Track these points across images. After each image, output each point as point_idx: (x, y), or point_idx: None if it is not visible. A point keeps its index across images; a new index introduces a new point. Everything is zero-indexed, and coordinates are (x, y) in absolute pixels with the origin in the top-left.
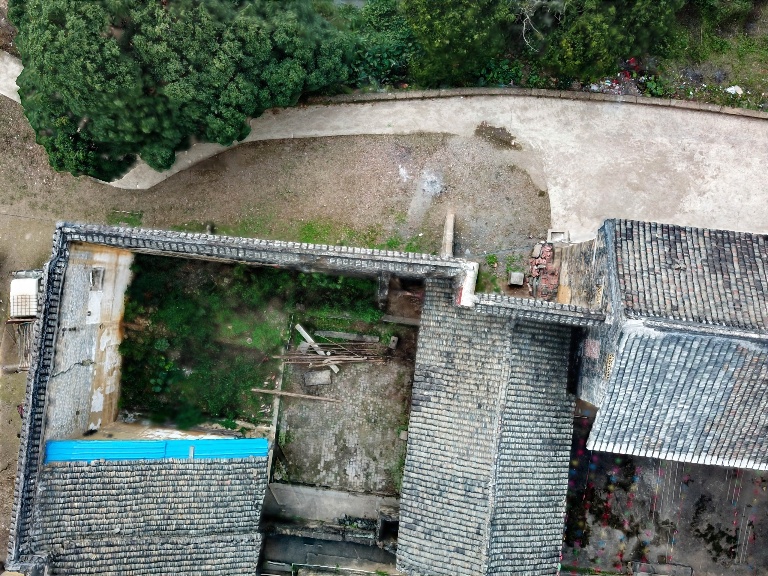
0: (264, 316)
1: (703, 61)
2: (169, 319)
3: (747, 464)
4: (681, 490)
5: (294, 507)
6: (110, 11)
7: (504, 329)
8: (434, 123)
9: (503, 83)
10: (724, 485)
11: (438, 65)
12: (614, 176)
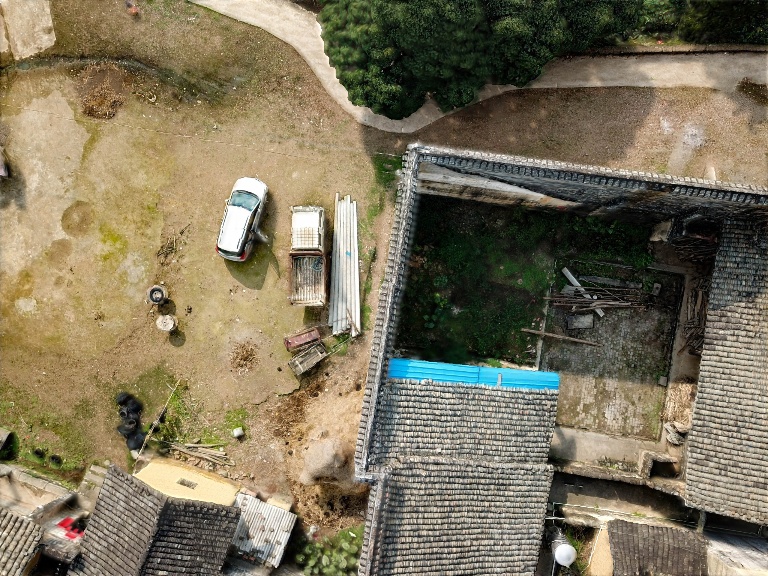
0: (532, 258)
1: None
2: (448, 256)
3: None
4: None
5: (555, 447)
6: None
7: None
8: (696, 78)
9: (764, 41)
10: None
11: (714, 19)
12: None
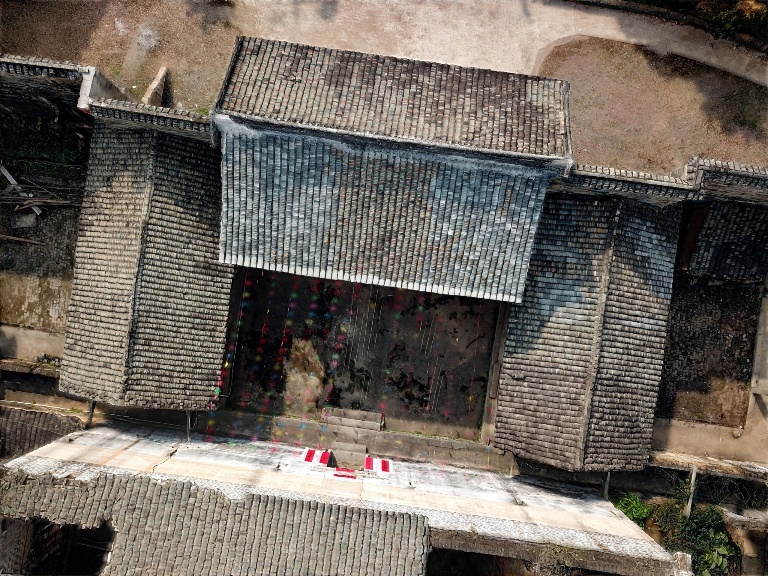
0: None
1: None
2: None
3: (373, 280)
4: (376, 339)
5: None
6: None
7: (149, 148)
8: None
9: None
10: (418, 335)
11: None
12: (323, 34)
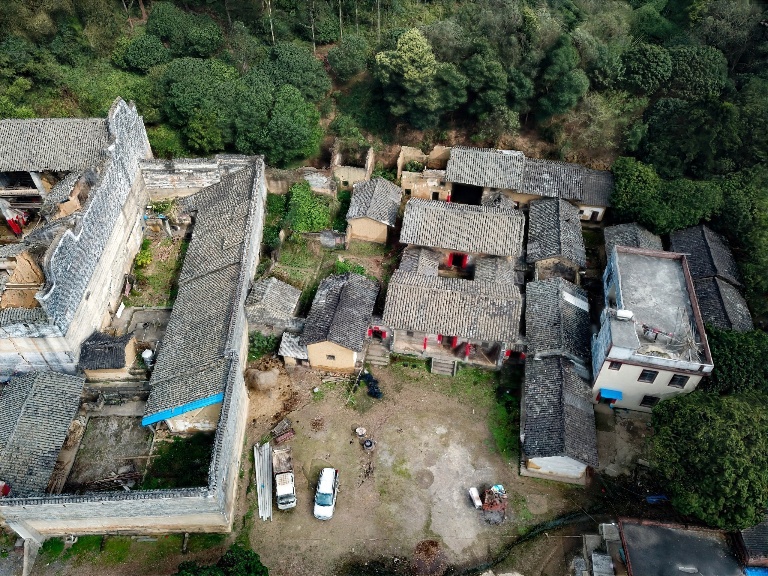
0: None
1: None
2: (200, 483)
3: None
4: None
5: None
6: None
7: None
8: None
9: None
10: None
11: None
12: None
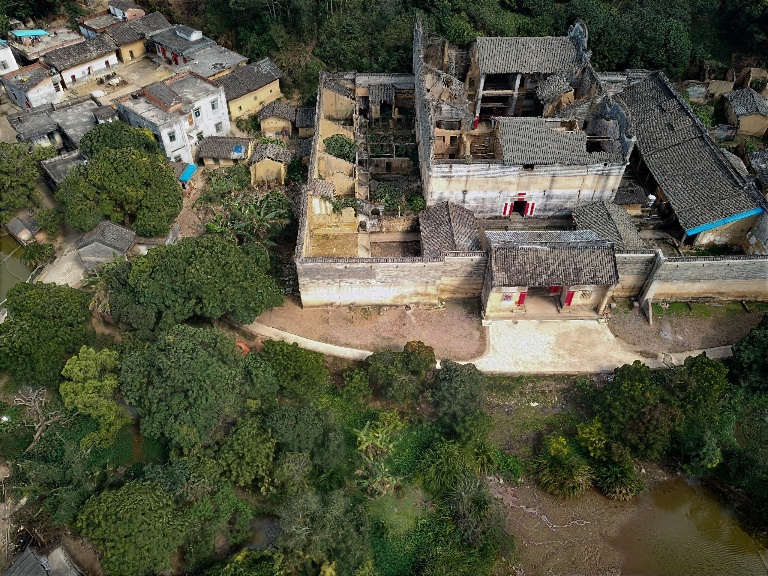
0: None
1: None
2: None
3: None
4: None
5: None
6: None
7: None
8: (678, 356)
9: None
10: None
11: None
12: (589, 345)
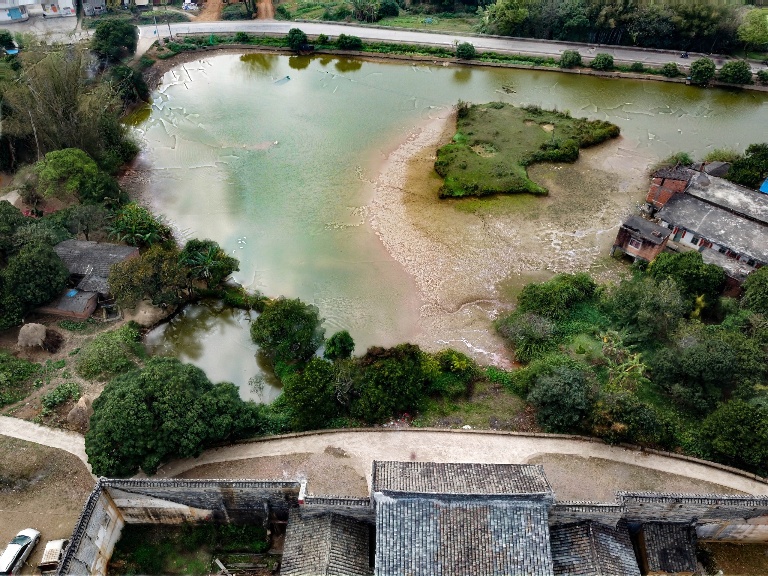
0: (197, 555)
1: (447, 415)
2: (139, 556)
3: None
4: None
5: None
6: (145, 392)
7: (327, 523)
8: (302, 448)
9: None
10: None
11: (302, 418)
12: None
